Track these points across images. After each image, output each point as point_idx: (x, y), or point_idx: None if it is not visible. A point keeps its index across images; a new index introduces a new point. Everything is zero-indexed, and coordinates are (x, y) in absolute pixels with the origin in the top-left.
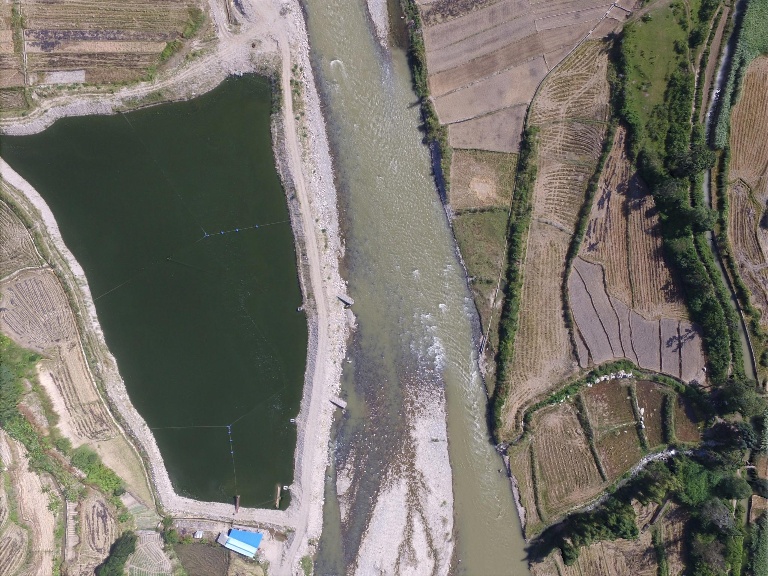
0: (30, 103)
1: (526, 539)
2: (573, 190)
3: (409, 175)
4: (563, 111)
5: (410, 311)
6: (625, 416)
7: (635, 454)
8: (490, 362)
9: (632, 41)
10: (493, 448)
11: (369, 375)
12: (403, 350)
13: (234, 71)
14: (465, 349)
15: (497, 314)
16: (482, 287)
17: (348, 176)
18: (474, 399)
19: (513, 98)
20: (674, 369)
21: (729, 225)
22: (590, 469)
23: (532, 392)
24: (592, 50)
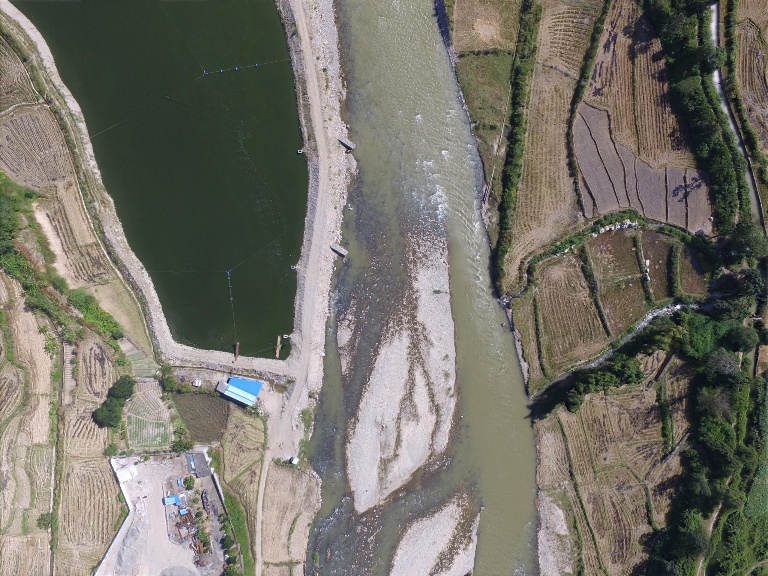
0: None
1: (529, 395)
2: (578, 33)
3: (412, 15)
4: None
5: (412, 157)
6: (630, 268)
7: (640, 308)
8: (493, 212)
9: None
10: (496, 302)
11: (370, 223)
12: (405, 198)
13: None
14: (468, 198)
15: (501, 162)
16: (485, 133)
17: (350, 15)
18: (477, 250)
19: None
20: (680, 219)
21: (737, 67)
22: (594, 323)
23: (536, 243)
24: None
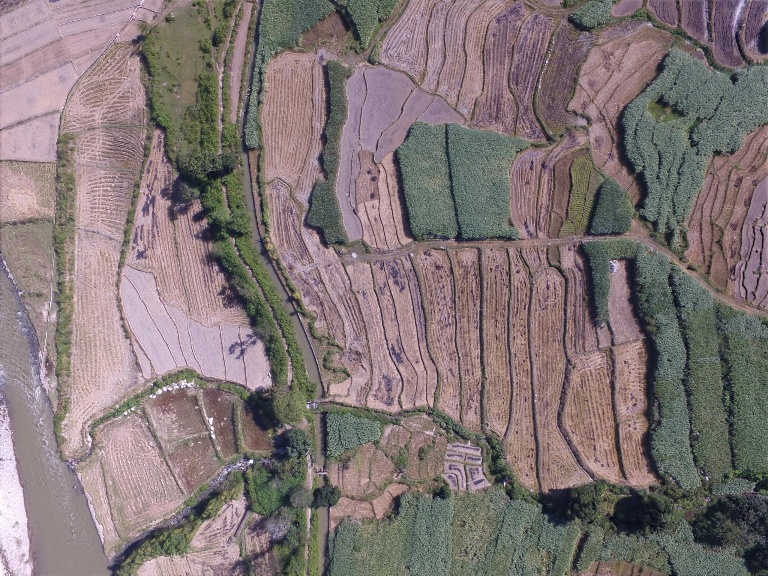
0: None
1: (107, 557)
2: (119, 197)
3: None
4: (98, 117)
5: None
6: (195, 426)
7: (211, 465)
8: (52, 377)
9: (157, 42)
10: (65, 465)
11: None
12: None
13: None
14: (25, 365)
15: (52, 328)
16: (33, 301)
17: None
18: (39, 416)
19: (44, 106)
20: (240, 376)
21: (272, 226)
22: (166, 482)
23: (97, 406)
24: (122, 53)
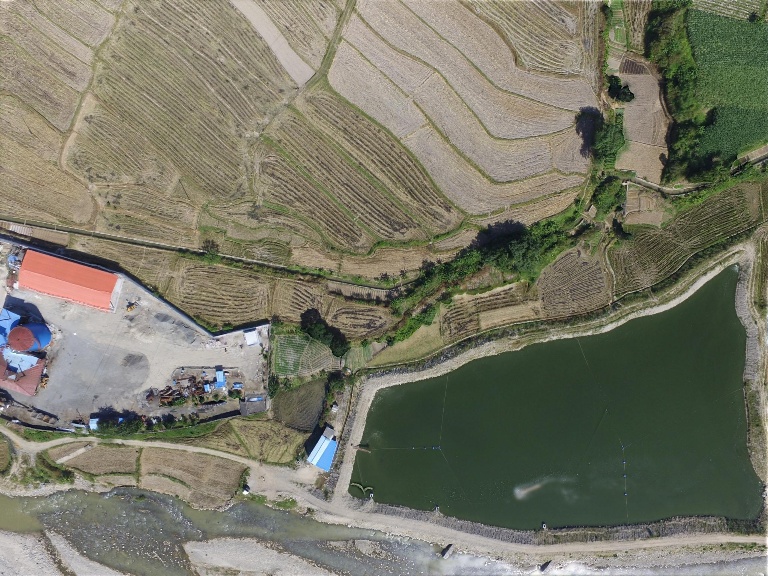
0: (765, 310)
1: None
2: None
3: None
4: None
5: None
6: None
7: None
8: None
9: None
10: None
11: None
12: None
13: (767, 490)
14: None
15: None
16: None
17: None
18: None
19: None
20: None
21: None
22: None
23: None
24: None
